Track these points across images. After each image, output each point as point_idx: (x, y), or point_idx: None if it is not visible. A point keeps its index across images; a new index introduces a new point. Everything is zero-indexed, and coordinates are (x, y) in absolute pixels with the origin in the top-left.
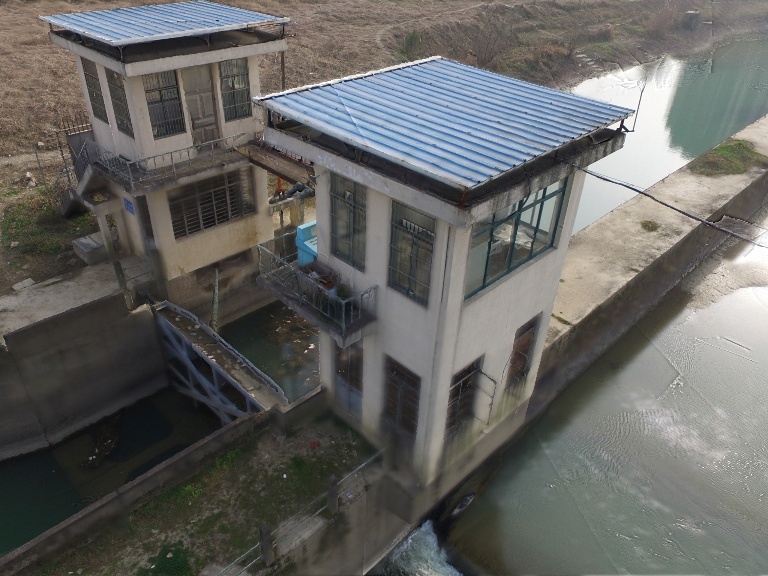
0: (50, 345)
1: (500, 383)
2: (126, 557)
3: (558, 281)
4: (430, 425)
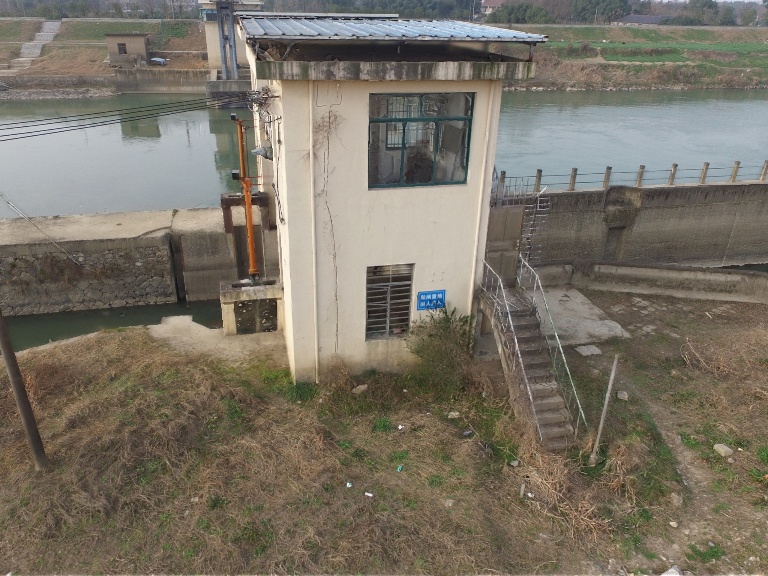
0: None
1: None
2: None
3: None
4: None
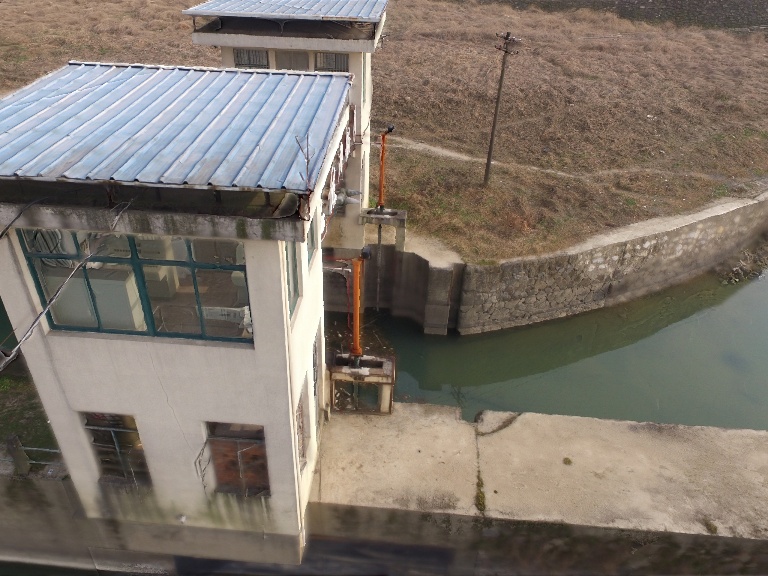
0: None
1: (196, 474)
2: None
3: (285, 400)
4: None
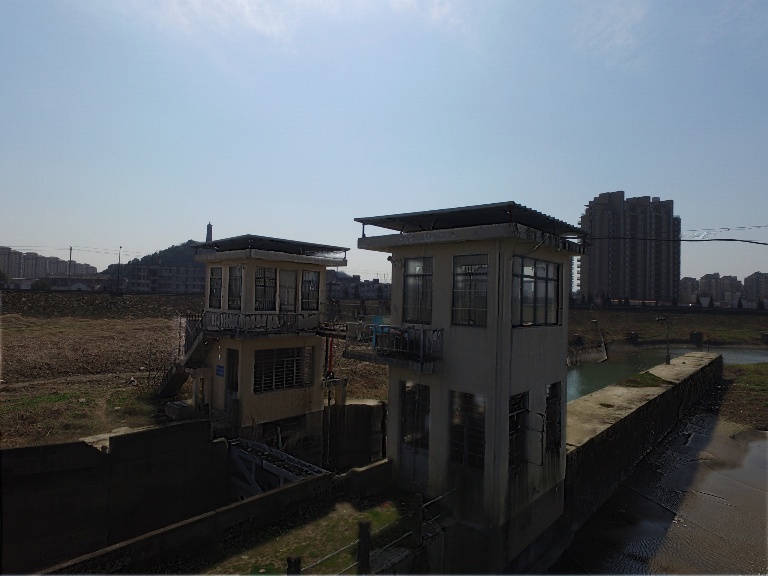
0: (142, 455)
1: None
2: (216, 575)
3: None
4: (497, 444)
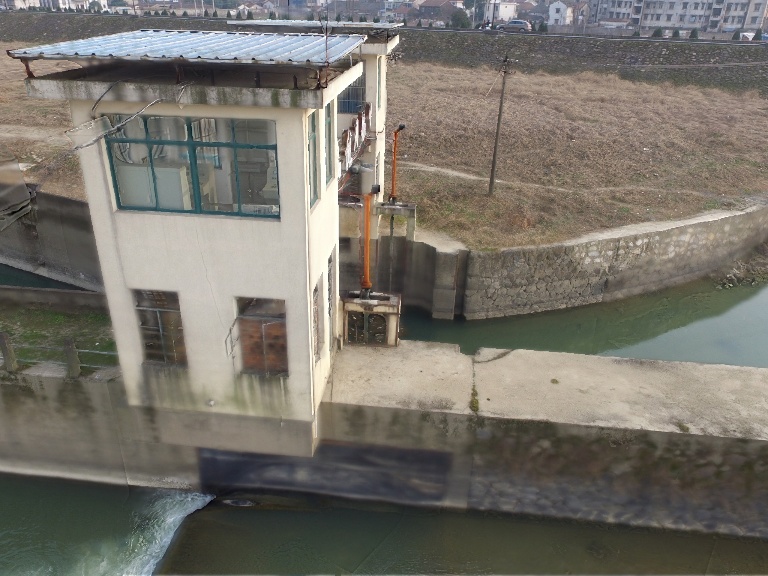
0: None
1: (226, 354)
2: None
3: (304, 272)
4: None
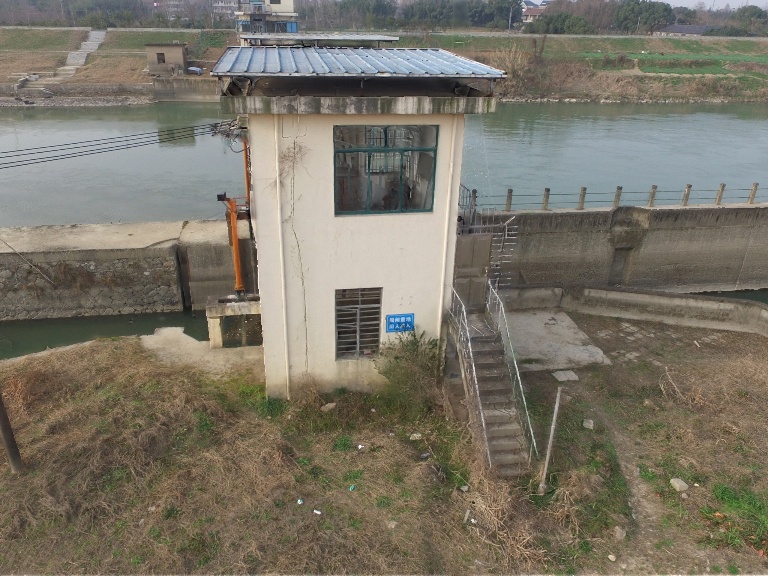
0: None
1: None
2: None
3: None
4: None
